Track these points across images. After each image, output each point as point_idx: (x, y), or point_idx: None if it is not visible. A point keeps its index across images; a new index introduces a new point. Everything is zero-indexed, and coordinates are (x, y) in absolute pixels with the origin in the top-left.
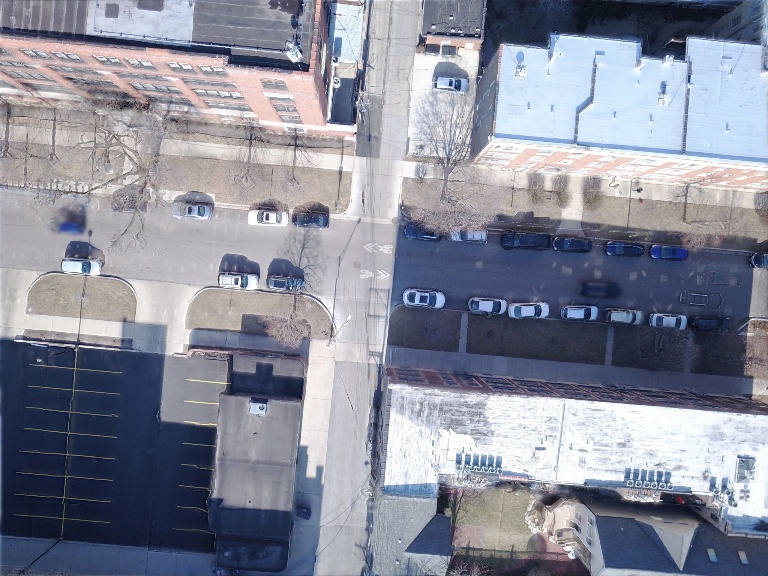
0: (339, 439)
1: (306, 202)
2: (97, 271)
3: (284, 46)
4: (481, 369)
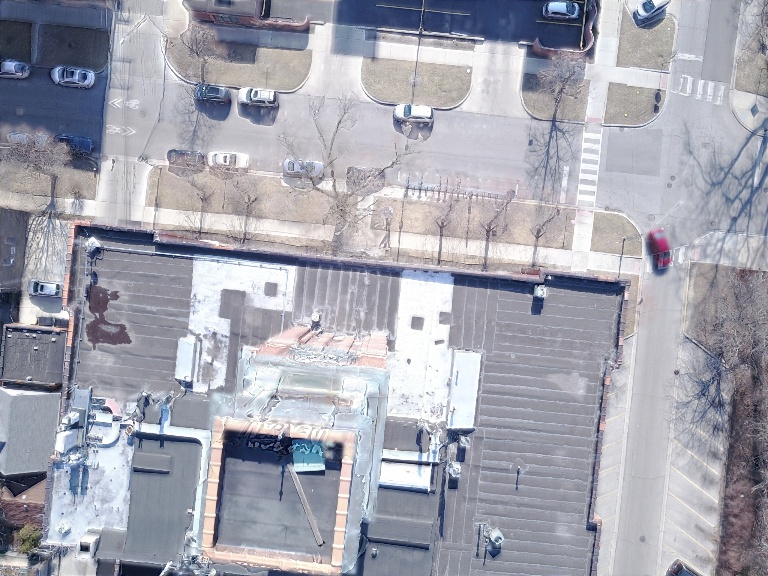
0: None
1: None
2: (398, 108)
3: (104, 255)
4: (17, 6)
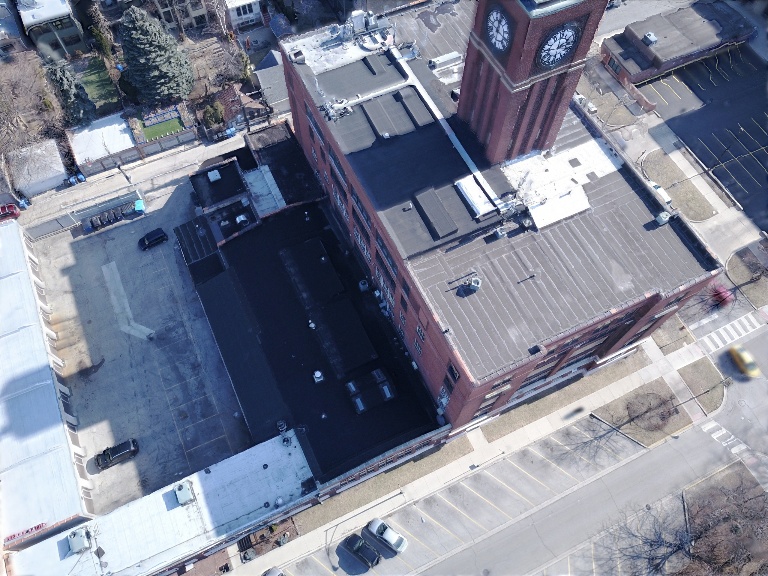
0: (625, 21)
1: None
2: (652, 183)
3: None
4: None
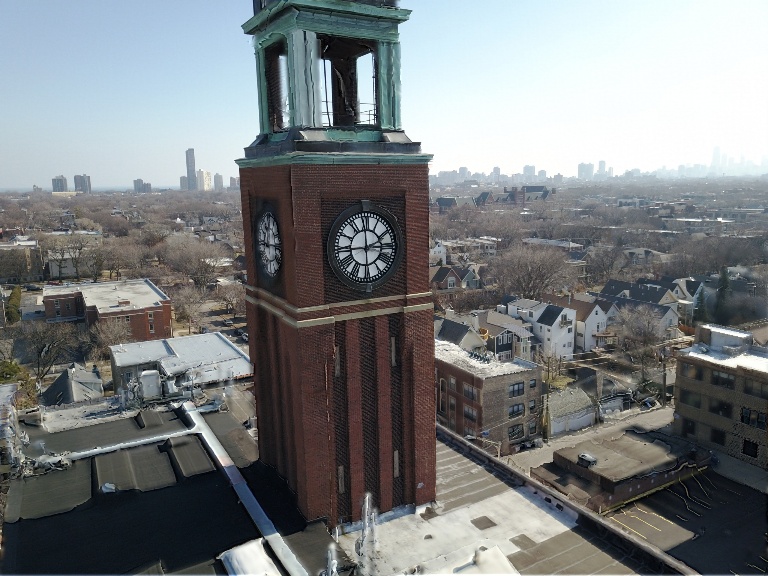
0: None
1: None
2: None
3: None
4: None
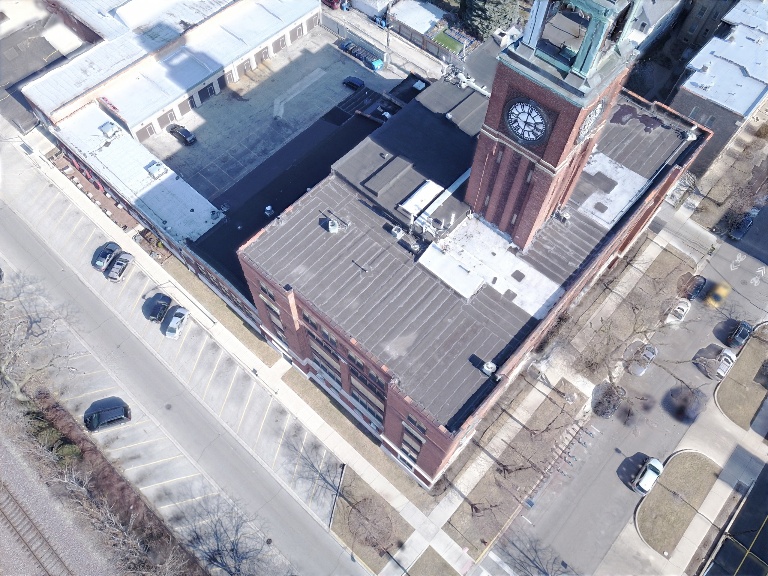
0: None
1: (677, 283)
2: (660, 465)
3: None
4: None
